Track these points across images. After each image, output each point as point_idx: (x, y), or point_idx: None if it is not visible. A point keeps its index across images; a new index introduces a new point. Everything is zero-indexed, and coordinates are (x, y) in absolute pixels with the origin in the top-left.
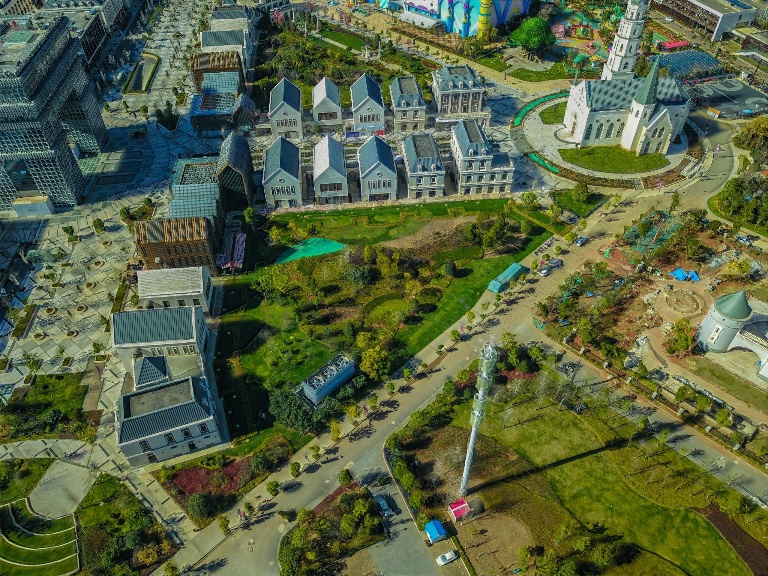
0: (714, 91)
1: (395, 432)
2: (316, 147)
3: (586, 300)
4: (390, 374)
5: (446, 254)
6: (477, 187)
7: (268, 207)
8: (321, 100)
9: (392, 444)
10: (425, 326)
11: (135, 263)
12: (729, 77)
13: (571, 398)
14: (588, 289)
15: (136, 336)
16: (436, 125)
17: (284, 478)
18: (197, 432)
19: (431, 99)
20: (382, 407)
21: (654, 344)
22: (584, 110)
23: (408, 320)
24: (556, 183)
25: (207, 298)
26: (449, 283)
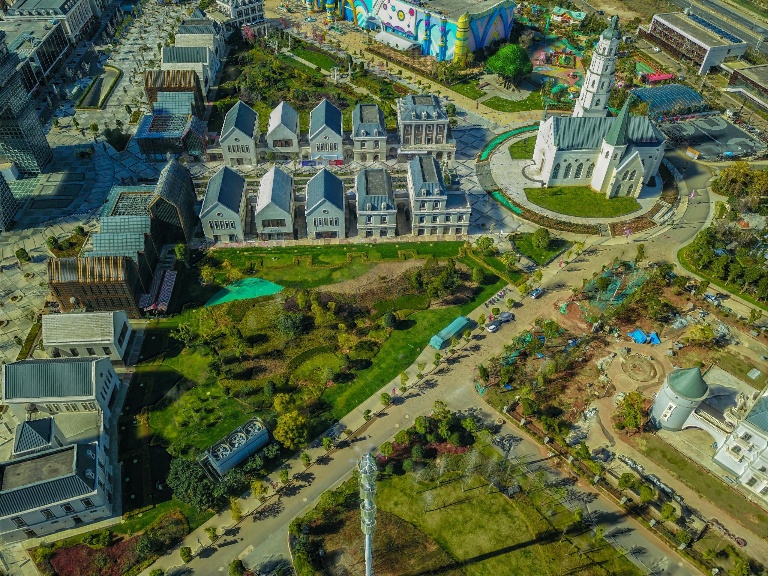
0: (696, 129)
1: (305, 512)
2: (263, 178)
3: (534, 362)
4: (309, 441)
5: (389, 303)
6: (431, 228)
7: (207, 241)
8: (275, 126)
9: (294, 531)
10: (356, 385)
11: (53, 300)
12: (713, 114)
13: (504, 478)
14: (536, 351)
15: (29, 391)
16: (398, 156)
17: (173, 563)
18: (80, 507)
19: None
20: (295, 480)
21: (603, 417)
22: (551, 148)
23: (338, 378)
24: (518, 225)
25: (120, 345)
26: (388, 336)
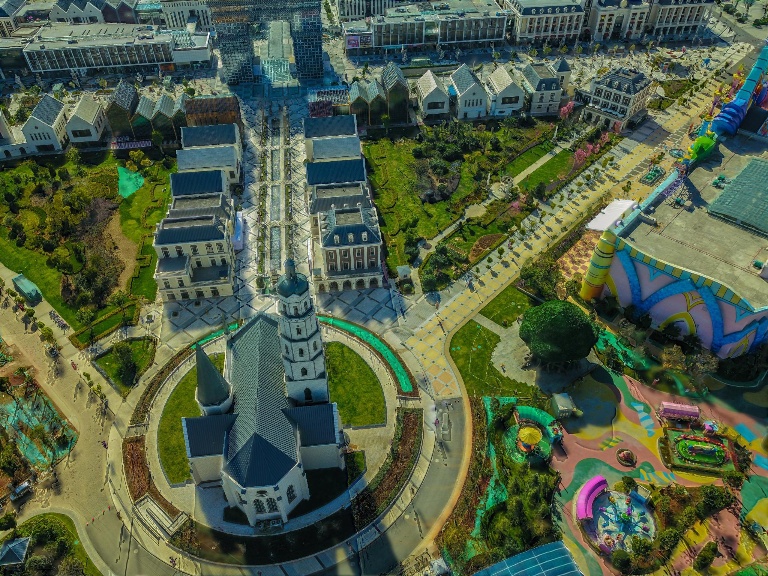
0: None
1: None
2: None
3: None
4: None
5: None
6: None
7: None
8: None
9: None
10: (3, 241)
11: None
12: None
13: None
14: None
15: None
16: None
17: None
18: None
19: None
20: None
21: None
22: None
23: (14, 231)
24: (171, 345)
25: (76, 136)
26: (43, 253)
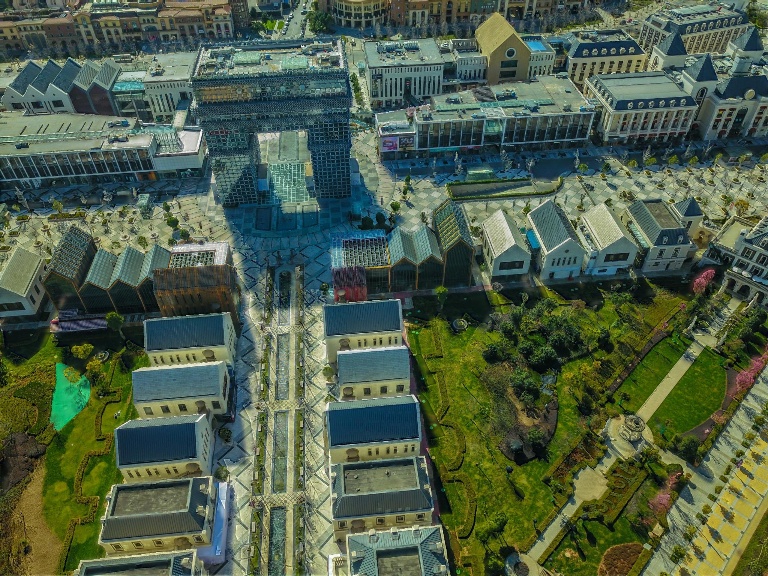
0: None
1: None
2: None
3: None
4: None
5: None
6: None
7: None
8: None
9: None
10: None
11: None
12: None
13: None
14: None
15: None
16: None
17: None
18: None
19: (455, 558)
20: None
21: None
22: None
23: None
24: None
25: (2, 310)
26: None
